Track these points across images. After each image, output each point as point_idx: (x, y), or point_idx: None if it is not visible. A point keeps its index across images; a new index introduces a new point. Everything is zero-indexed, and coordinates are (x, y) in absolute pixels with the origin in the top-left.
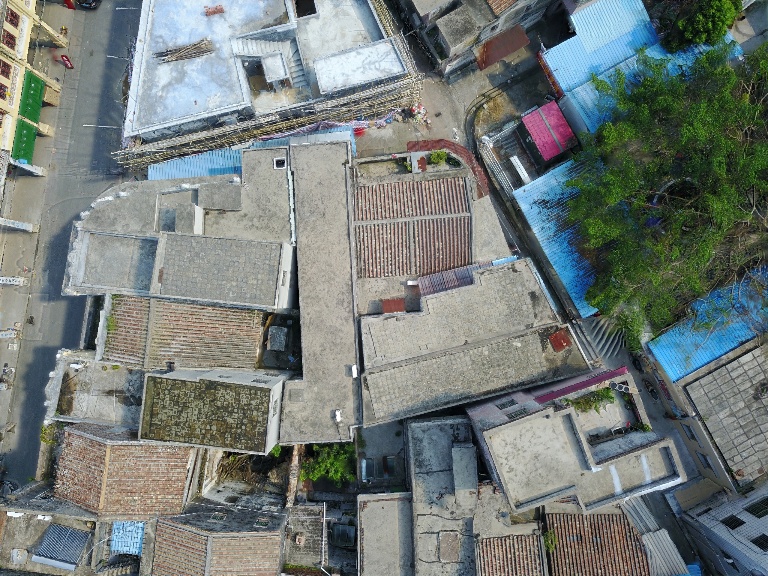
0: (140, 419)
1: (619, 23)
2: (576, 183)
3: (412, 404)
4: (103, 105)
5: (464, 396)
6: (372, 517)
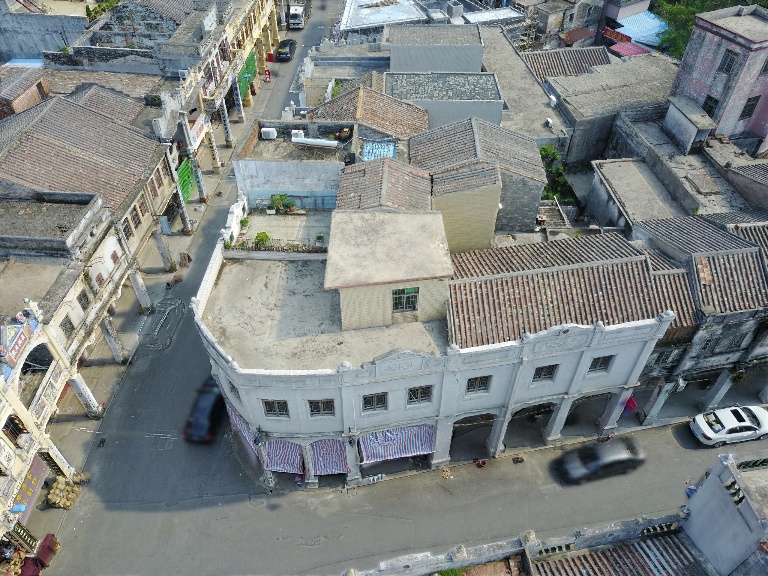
0: (383, 90)
1: (648, 24)
2: (669, 36)
3: (612, 108)
4: (291, 94)
5: (654, 103)
6: (613, 172)
